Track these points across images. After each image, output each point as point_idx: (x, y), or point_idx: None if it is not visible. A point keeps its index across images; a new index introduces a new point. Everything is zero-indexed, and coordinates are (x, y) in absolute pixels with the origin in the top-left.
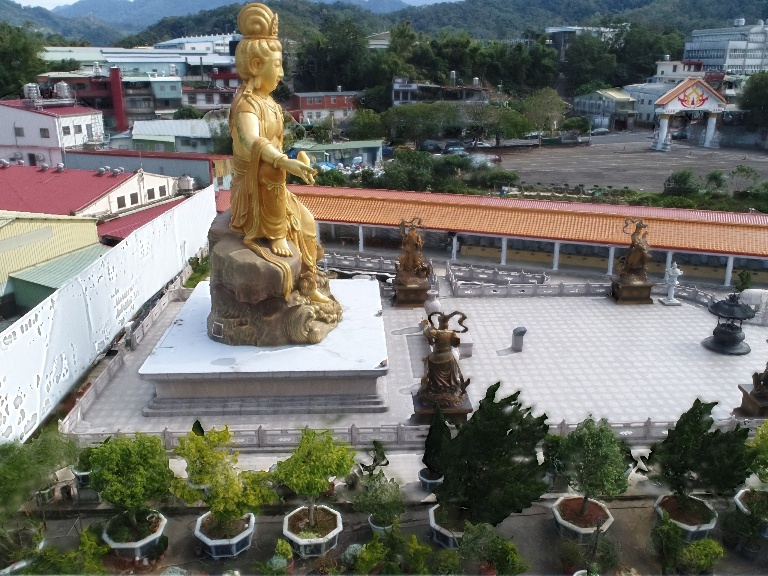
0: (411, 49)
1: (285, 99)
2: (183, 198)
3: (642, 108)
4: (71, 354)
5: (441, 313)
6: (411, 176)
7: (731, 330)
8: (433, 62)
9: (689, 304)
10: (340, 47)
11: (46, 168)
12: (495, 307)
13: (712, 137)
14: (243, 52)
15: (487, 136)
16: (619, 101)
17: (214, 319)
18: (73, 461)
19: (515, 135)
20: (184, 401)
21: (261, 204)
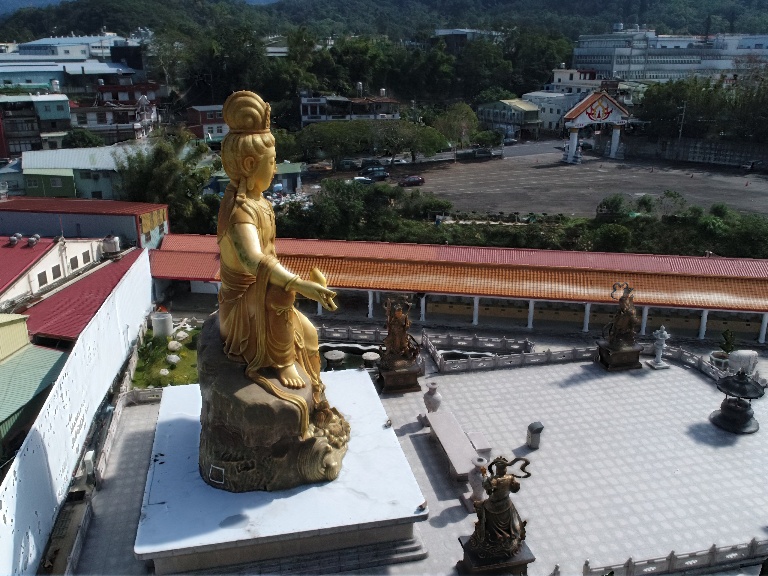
0: (311, 57)
1: (182, 113)
2: (110, 263)
3: (544, 116)
4: (36, 525)
5: (503, 461)
6: (341, 208)
7: (739, 406)
8: (334, 70)
9: (676, 366)
10: (238, 56)
11: None
12: (488, 385)
13: (617, 148)
14: (233, 150)
15: (399, 150)
16: (528, 113)
17: (211, 462)
18: None
19: (434, 153)
20: (190, 575)
21: (267, 331)
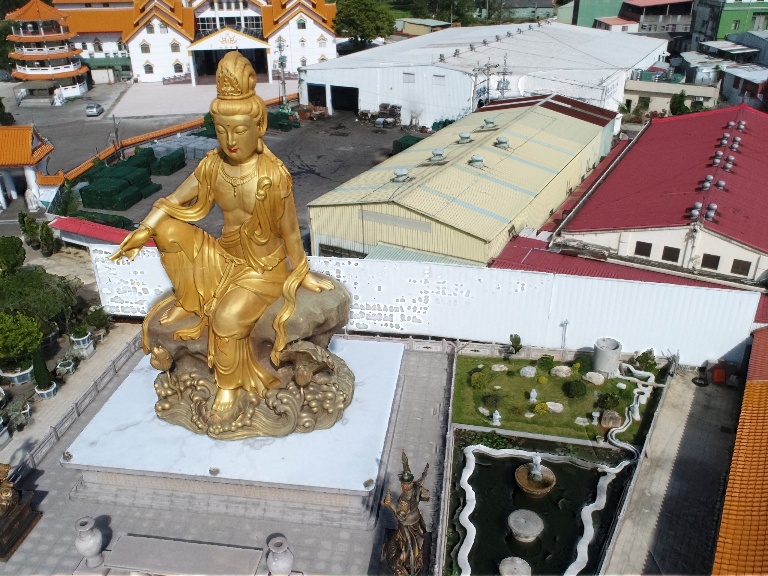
0: None
1: None
2: None
3: None
4: None
5: None
6: None
7: None
8: None
9: None
10: None
11: (707, 181)
12: None
13: None
14: None
15: None
16: None
17: None
18: (39, 315)
19: None
20: None
21: None
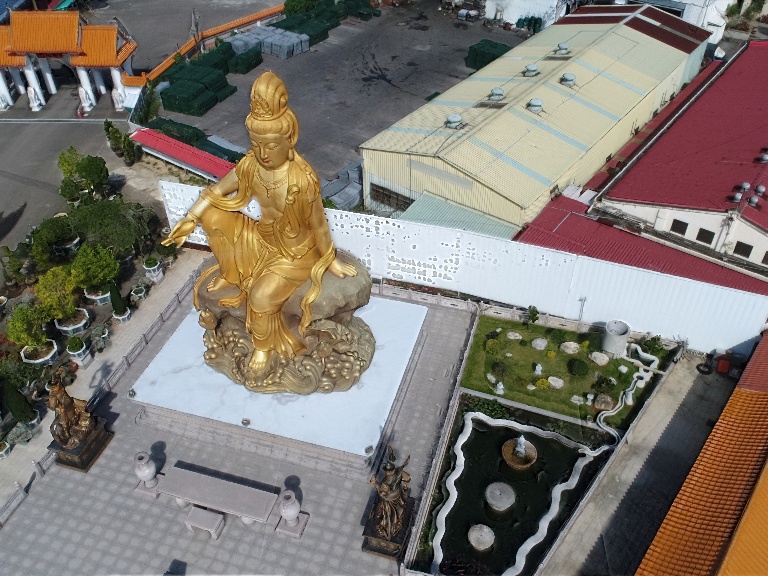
0: None
1: None
2: None
3: None
4: None
5: None
6: None
7: None
8: None
9: None
10: None
11: None
12: None
13: None
14: None
15: None
16: None
17: None
18: None
19: None
20: None
21: None
